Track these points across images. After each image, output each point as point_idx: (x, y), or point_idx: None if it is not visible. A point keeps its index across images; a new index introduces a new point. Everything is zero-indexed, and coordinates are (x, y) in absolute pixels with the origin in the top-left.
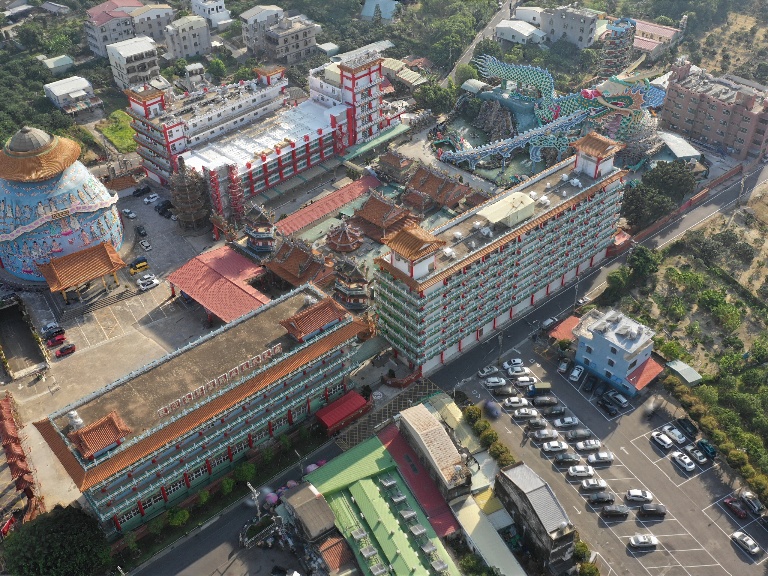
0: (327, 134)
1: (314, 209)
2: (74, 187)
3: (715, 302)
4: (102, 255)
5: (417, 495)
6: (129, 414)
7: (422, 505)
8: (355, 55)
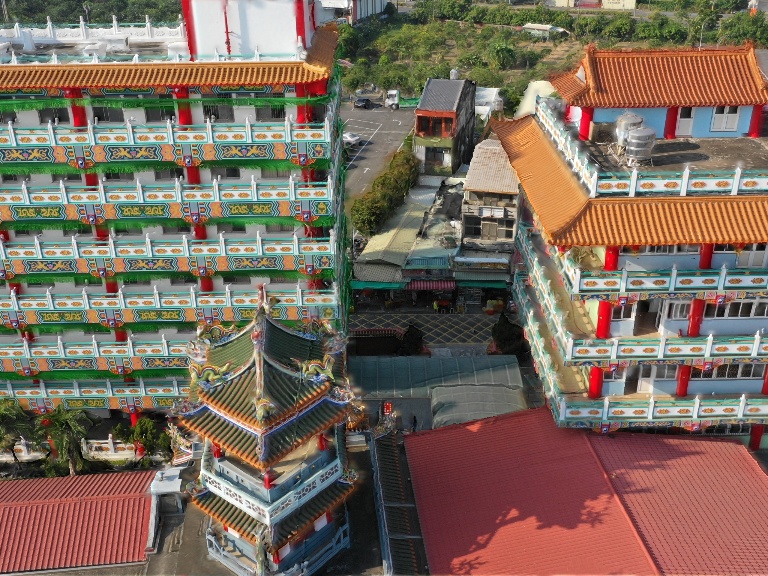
0: None
1: None
2: None
3: None
4: None
5: None
6: None
7: None
8: None
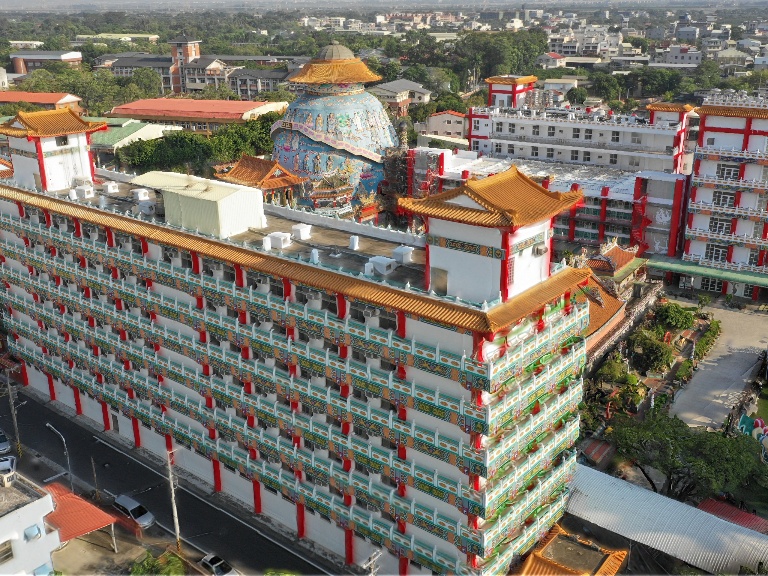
0: (623, 206)
1: None
2: (319, 109)
3: None
4: (267, 172)
5: None
6: None
7: None
8: None
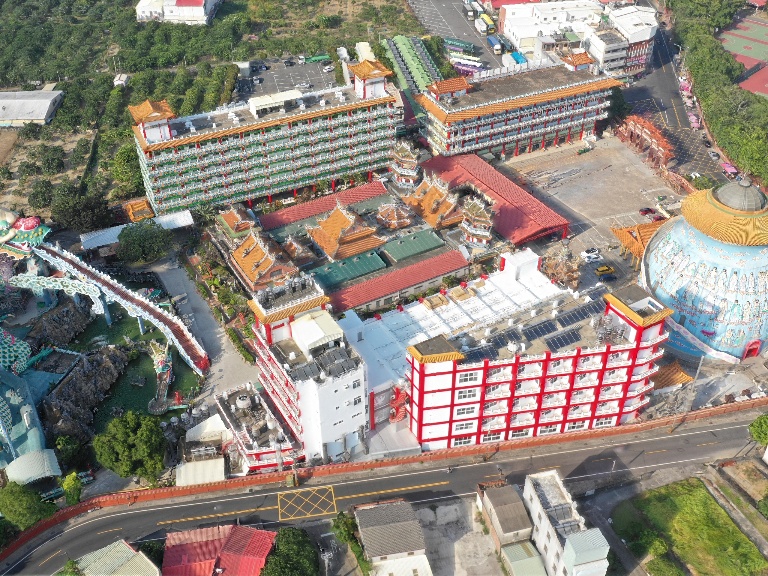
0: None
1: (413, 270)
2: None
3: (131, 150)
4: None
5: (407, 100)
6: (566, 74)
7: (406, 98)
8: (294, 301)
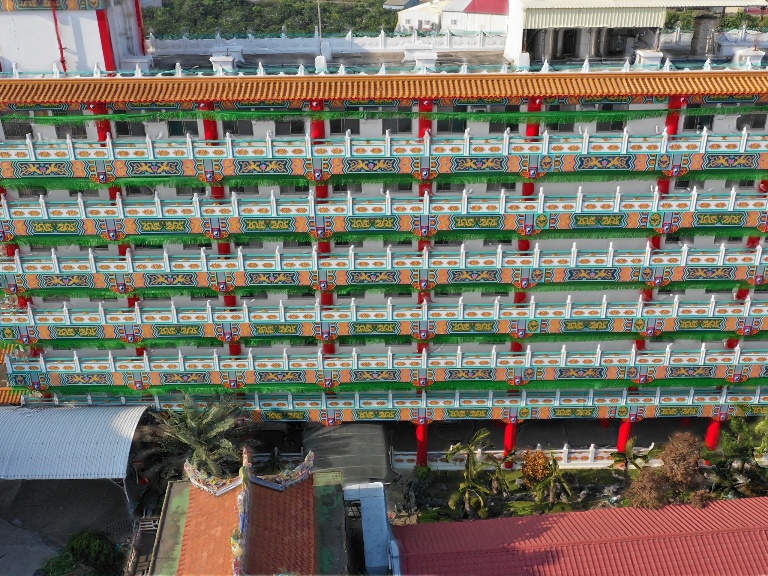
0: None
1: None
2: None
3: None
4: None
5: None
6: None
7: None
8: None
